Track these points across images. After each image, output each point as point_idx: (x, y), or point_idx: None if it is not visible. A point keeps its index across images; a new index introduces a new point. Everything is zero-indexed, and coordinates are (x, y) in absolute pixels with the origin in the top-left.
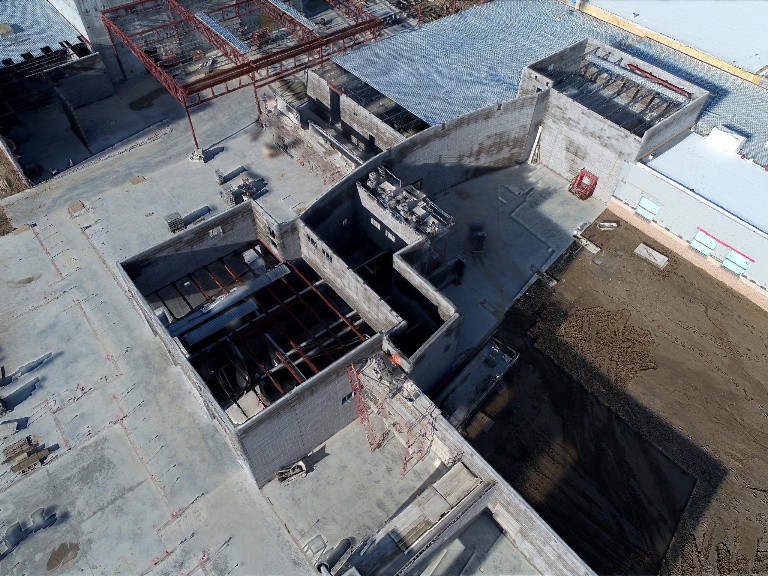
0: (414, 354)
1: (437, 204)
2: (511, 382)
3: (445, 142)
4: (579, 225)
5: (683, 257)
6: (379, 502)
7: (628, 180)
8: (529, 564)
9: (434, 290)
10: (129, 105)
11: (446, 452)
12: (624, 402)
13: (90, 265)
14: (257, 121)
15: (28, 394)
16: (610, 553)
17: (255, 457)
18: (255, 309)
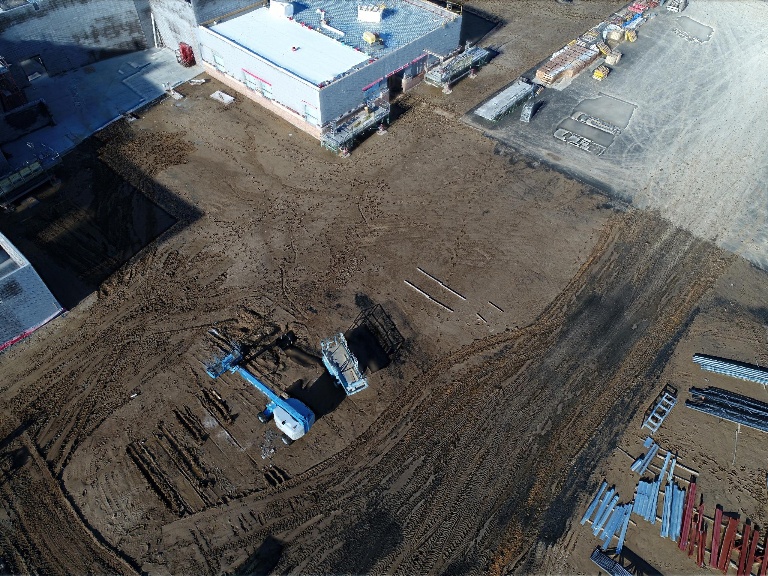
0: None
1: (64, 78)
2: (67, 179)
3: (47, 22)
4: (175, 83)
5: (247, 97)
6: None
7: (202, 43)
8: None
9: None
10: None
11: None
12: (149, 183)
13: None
14: None
15: None
16: (89, 262)
17: None
18: None
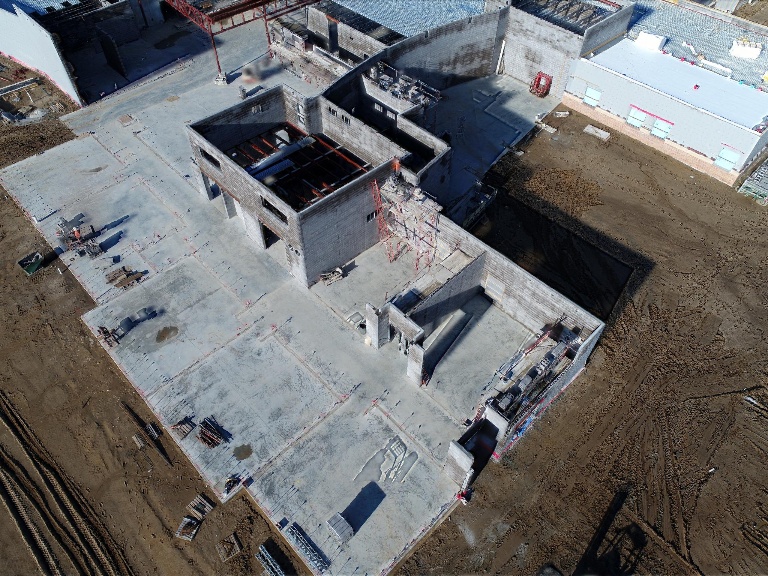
0: (420, 171)
1: None
2: (492, 217)
3: (428, 49)
4: None
5: (622, 133)
6: (399, 291)
7: (575, 75)
8: (513, 320)
9: (431, 134)
10: (154, 46)
11: (447, 250)
12: (579, 225)
13: (146, 157)
14: (266, 53)
15: (116, 241)
16: None
17: (308, 249)
18: (292, 165)
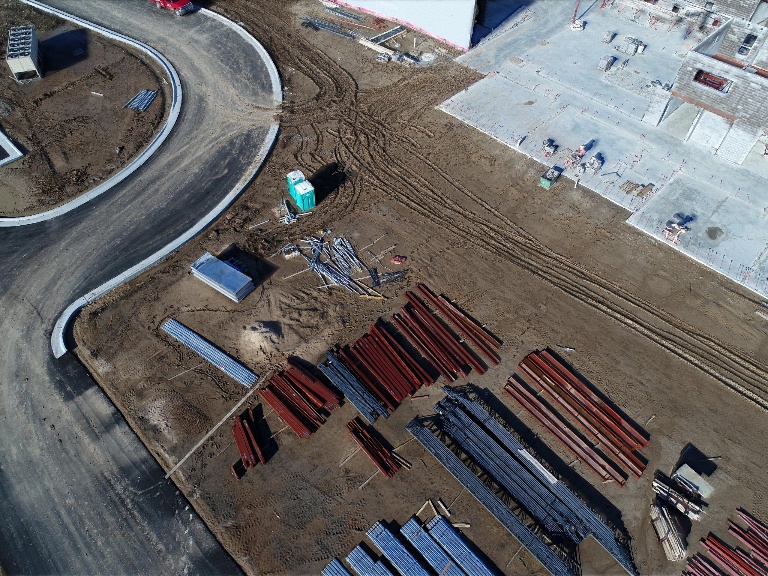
0: None
1: None
2: None
3: None
4: None
5: None
6: None
7: None
8: None
9: None
10: None
11: None
12: None
13: (565, 92)
14: (594, 4)
15: (602, 161)
16: None
17: None
18: None
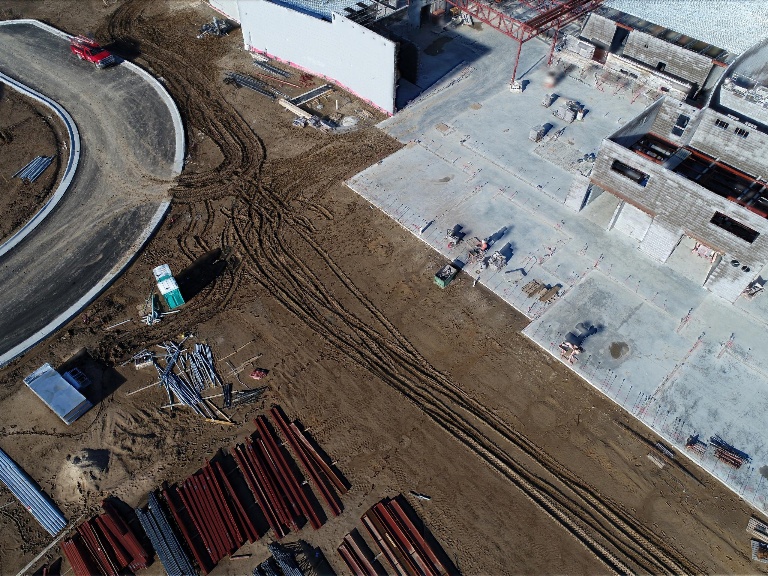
0: None
1: None
2: None
3: (753, 59)
4: None
5: None
6: None
7: None
8: None
9: None
10: (424, 52)
11: None
12: None
13: (487, 167)
14: (541, 60)
15: (510, 254)
16: None
17: None
18: None
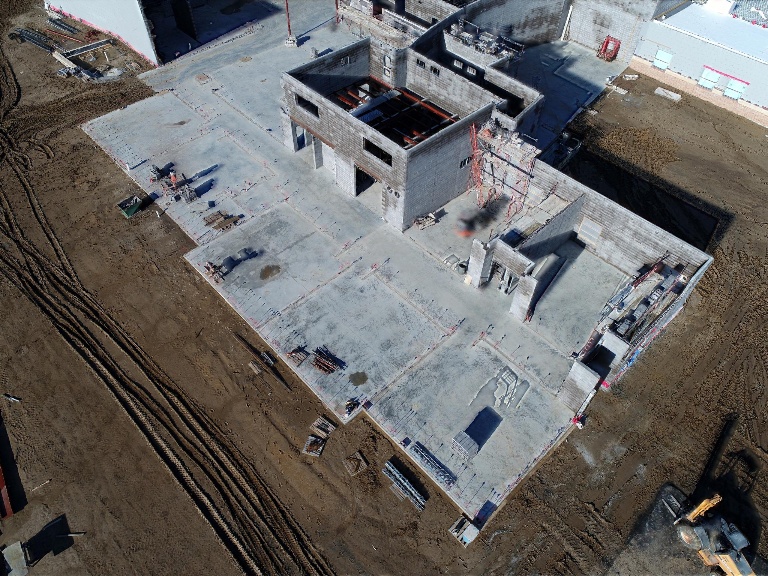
0: (517, 116)
1: None
2: (574, 171)
3: (502, 10)
4: None
5: (692, 95)
6: None
7: (646, 37)
8: (607, 263)
9: (522, 84)
10: (221, 11)
11: (539, 196)
12: (660, 179)
13: (227, 112)
14: (332, 19)
15: (208, 188)
16: None
17: (409, 190)
18: (381, 115)
